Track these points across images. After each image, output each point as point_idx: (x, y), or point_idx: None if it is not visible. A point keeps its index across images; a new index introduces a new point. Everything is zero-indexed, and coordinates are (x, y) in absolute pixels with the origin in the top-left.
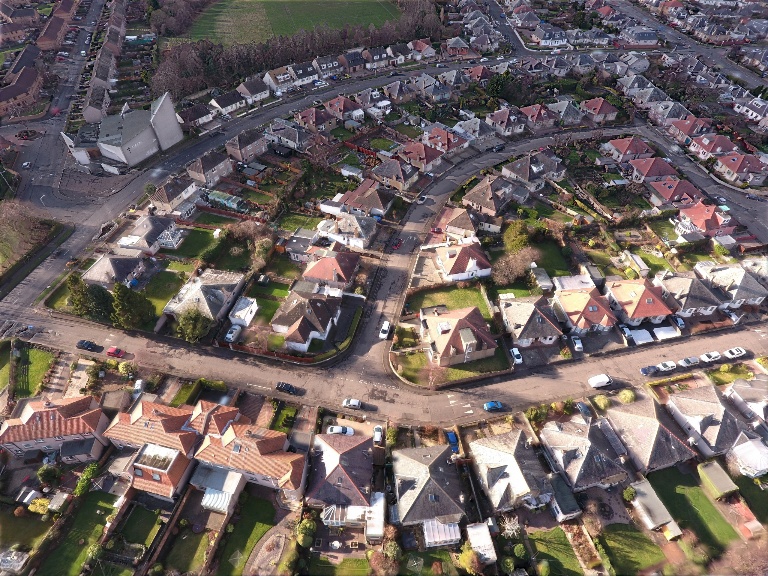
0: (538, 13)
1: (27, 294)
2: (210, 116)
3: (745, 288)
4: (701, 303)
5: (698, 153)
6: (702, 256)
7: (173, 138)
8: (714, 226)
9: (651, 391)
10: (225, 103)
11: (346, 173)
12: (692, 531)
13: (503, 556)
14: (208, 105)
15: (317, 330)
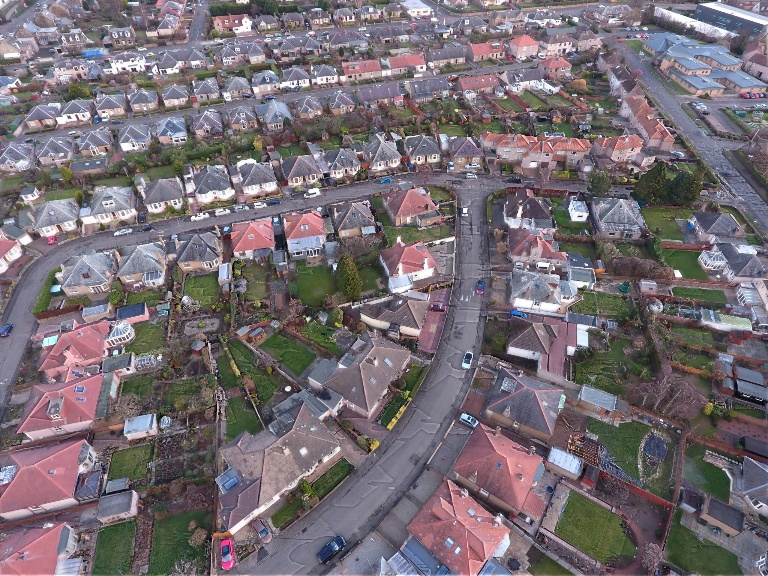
0: None
1: (762, 216)
2: None
3: None
4: None
5: None
6: None
7: None
8: None
9: None
10: None
11: None
12: (298, 150)
13: (387, 137)
14: None
15: None
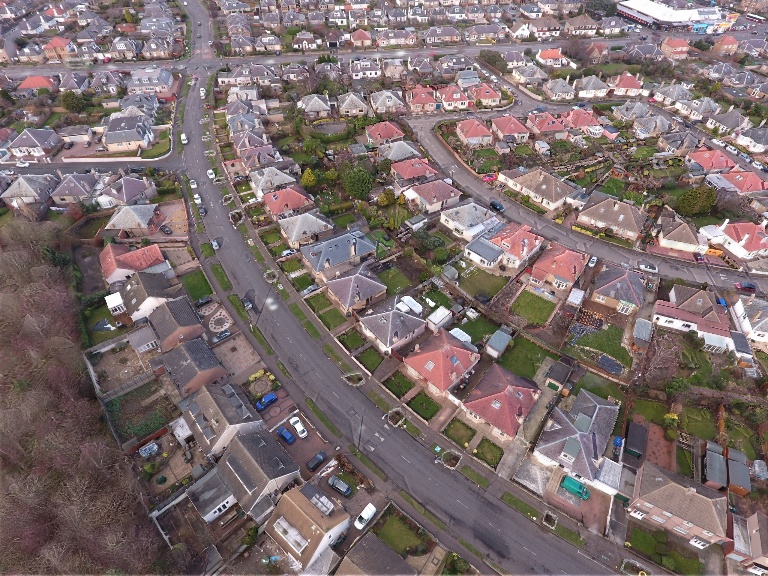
0: None
1: None
2: None
3: None
4: None
5: (456, 107)
6: None
7: None
8: None
9: None
10: None
11: None
12: None
13: None
14: None
15: None
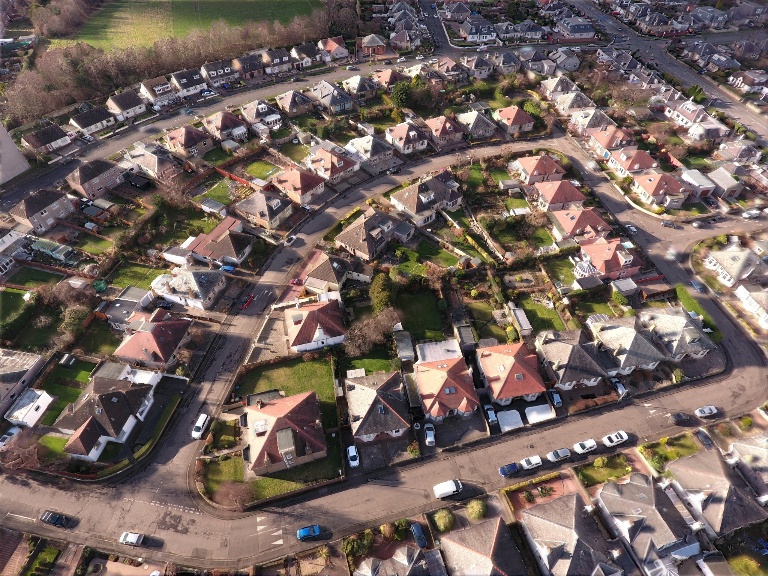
0: (472, 3)
1: None
2: (67, 138)
3: (635, 353)
4: (582, 375)
5: (616, 170)
6: (599, 305)
7: (14, 169)
8: (615, 267)
9: (505, 501)
10: (87, 122)
11: (207, 209)
12: None
13: None
14: (68, 125)
15: (108, 434)
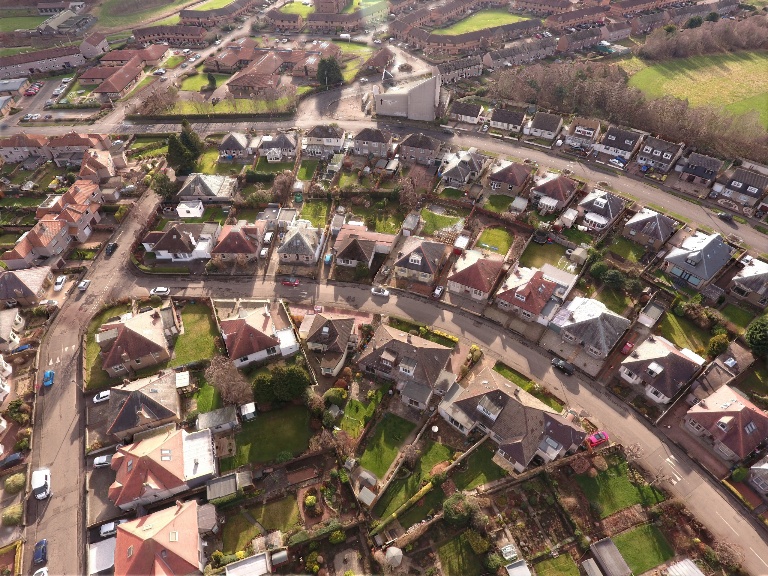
0: None
1: (222, 128)
2: (476, 120)
3: None
4: None
5: None
6: None
7: (423, 115)
8: None
9: (6, 545)
10: (499, 118)
11: None
12: None
13: None
14: None
15: None
